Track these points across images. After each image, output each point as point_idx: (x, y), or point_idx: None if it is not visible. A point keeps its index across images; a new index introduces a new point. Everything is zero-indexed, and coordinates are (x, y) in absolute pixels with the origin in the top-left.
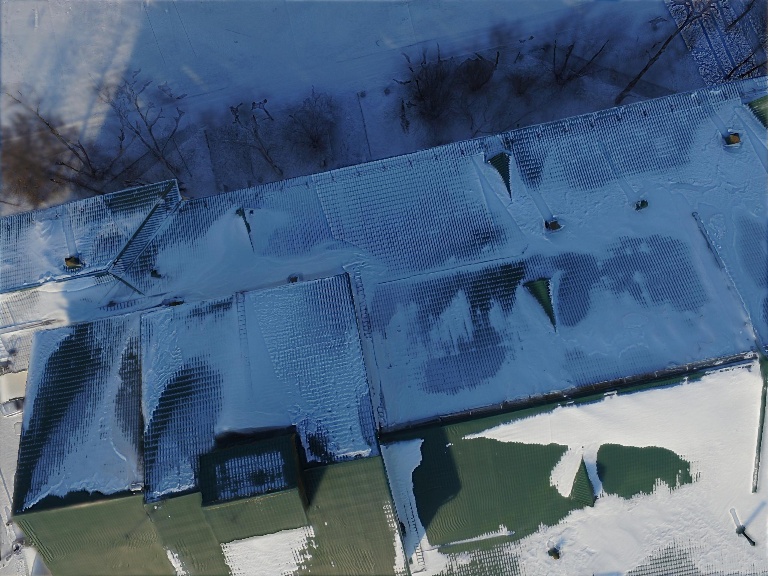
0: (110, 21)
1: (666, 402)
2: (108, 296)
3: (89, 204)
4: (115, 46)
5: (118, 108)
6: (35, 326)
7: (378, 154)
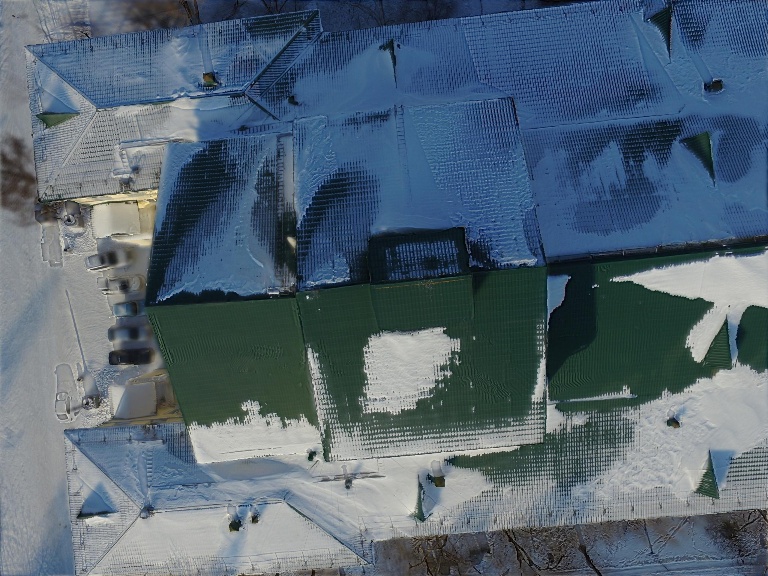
0: None
1: None
2: (240, 120)
3: (228, 26)
4: None
5: None
6: (162, 143)
7: None
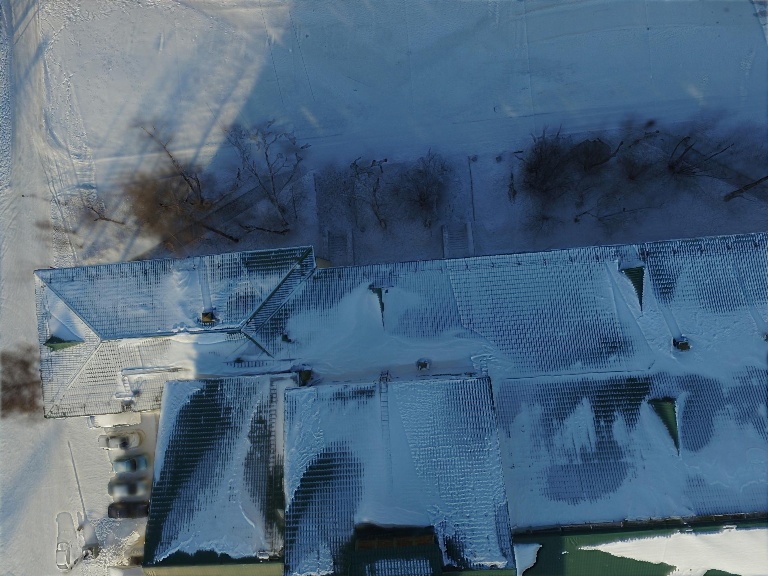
0: (234, 54)
1: None
2: (236, 352)
3: (226, 260)
4: (236, 79)
5: (243, 151)
6: (162, 371)
7: (482, 219)
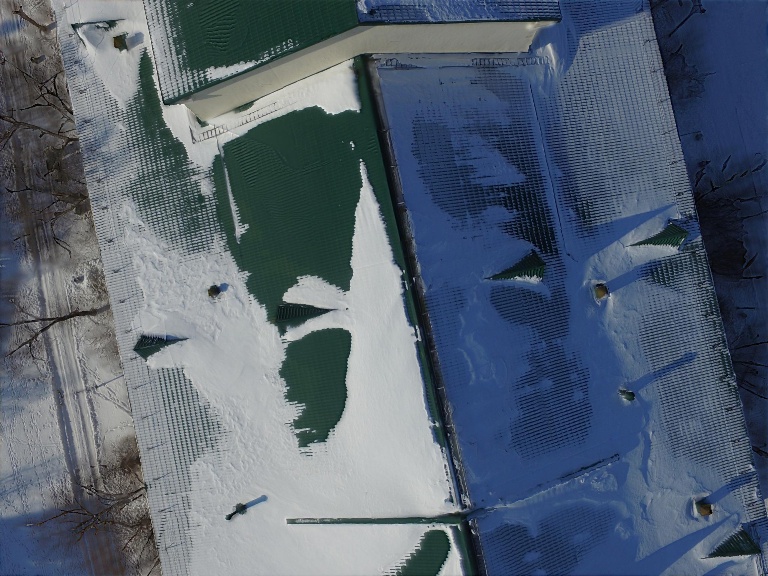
0: None
1: (406, 402)
2: None
3: None
4: None
5: None
6: None
7: None
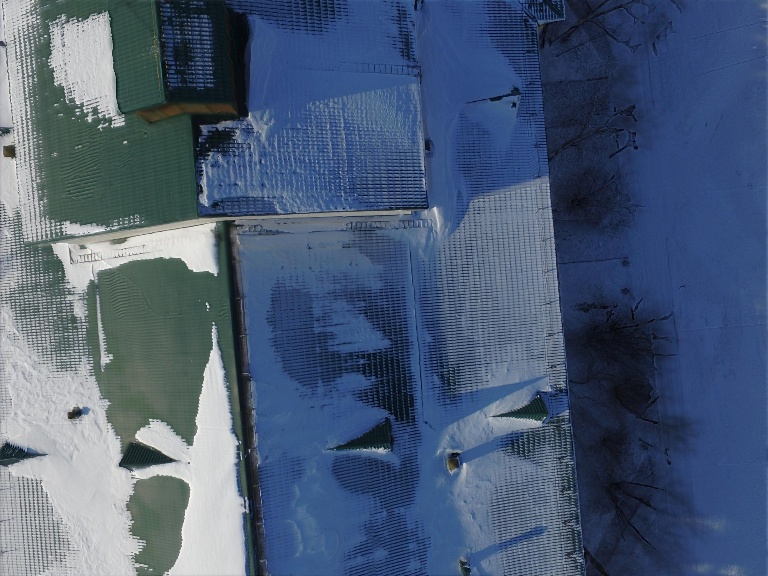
0: None
1: (230, 568)
2: None
3: None
4: None
5: None
6: None
7: None
